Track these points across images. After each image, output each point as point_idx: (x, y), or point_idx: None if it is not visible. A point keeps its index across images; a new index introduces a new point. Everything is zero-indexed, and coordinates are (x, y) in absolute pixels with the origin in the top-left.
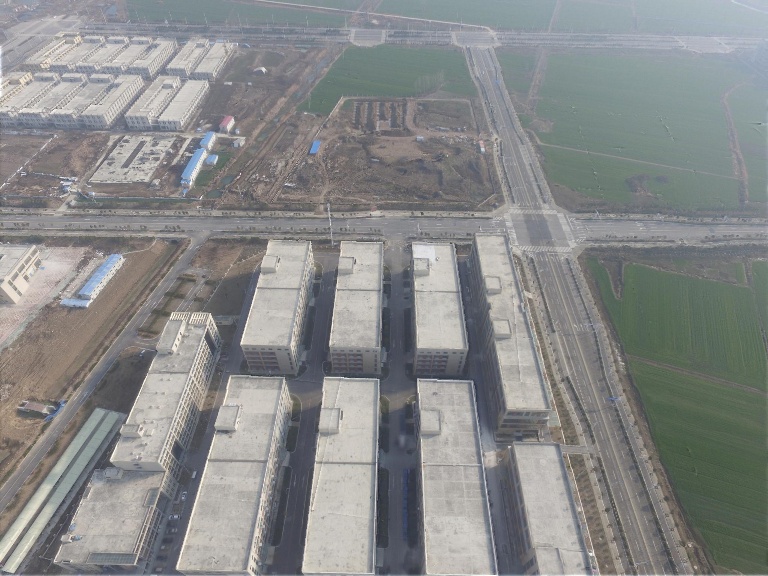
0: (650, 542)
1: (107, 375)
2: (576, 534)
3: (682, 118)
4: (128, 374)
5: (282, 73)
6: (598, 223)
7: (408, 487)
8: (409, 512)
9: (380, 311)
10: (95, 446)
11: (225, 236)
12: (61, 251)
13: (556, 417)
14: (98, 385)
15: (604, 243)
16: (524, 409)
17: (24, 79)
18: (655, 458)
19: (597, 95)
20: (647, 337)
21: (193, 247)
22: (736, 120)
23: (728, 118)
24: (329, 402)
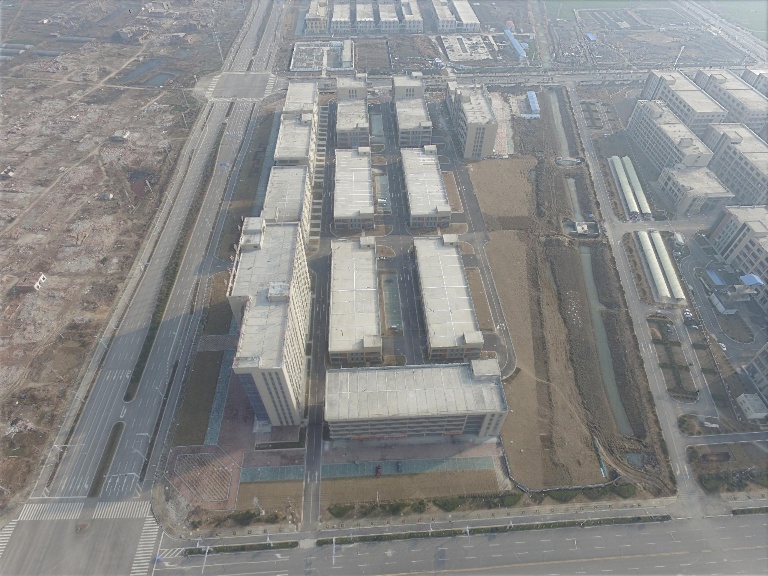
0: None
1: (596, 145)
2: None
3: None
4: (608, 144)
5: None
6: None
7: None
8: None
9: (764, 97)
10: (633, 169)
11: (586, 83)
12: None
13: None
14: (595, 149)
15: None
16: None
17: None
18: None
19: (764, 3)
20: None
21: (571, 89)
22: None
23: None
24: None
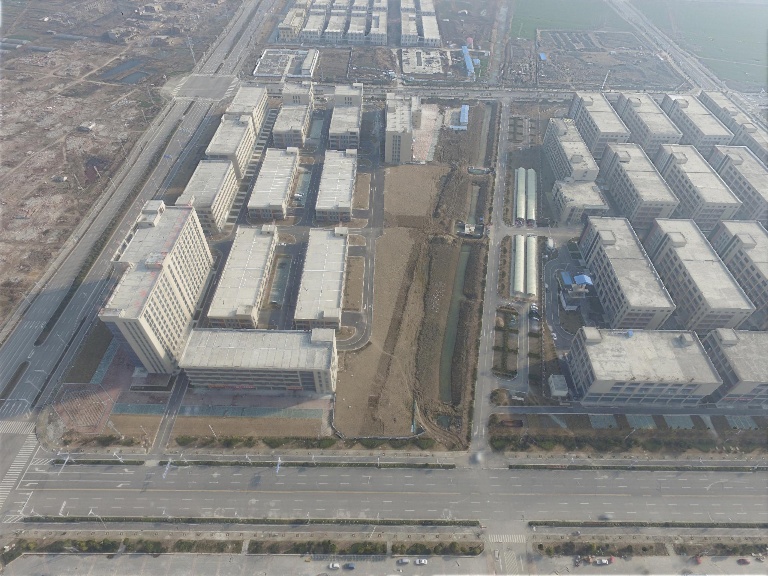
0: None
1: (509, 157)
2: None
3: None
4: (521, 157)
5: (479, 15)
6: (763, 98)
7: None
8: None
9: (670, 121)
10: None
11: (522, 100)
12: (422, 106)
13: None
14: (507, 161)
15: None
16: None
17: None
18: None
19: (724, 31)
20: None
21: (505, 105)
22: None
23: None
24: None
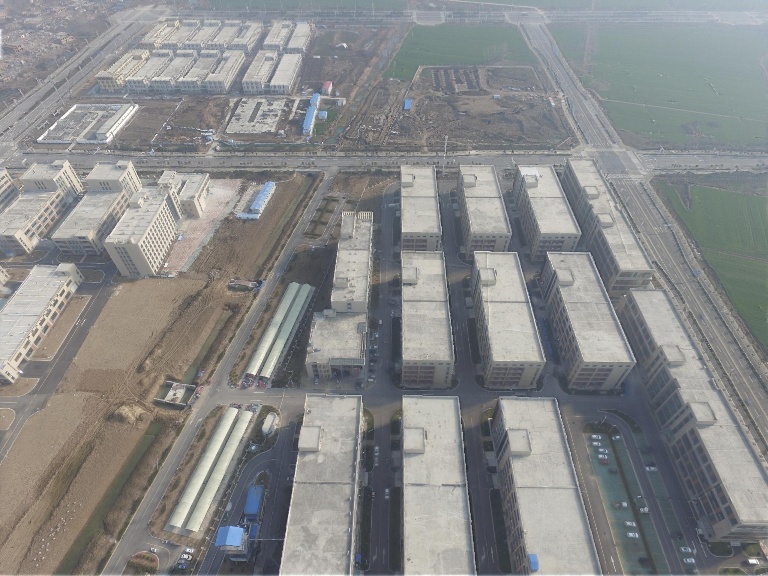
0: (737, 362)
1: (291, 262)
2: (688, 341)
3: (724, 78)
4: (307, 262)
5: (361, 48)
6: (663, 157)
7: (547, 328)
8: (551, 342)
9: (505, 210)
10: (300, 305)
11: (352, 170)
12: (222, 182)
13: (652, 287)
14: (286, 269)
15: (670, 171)
16: (634, 269)
17: (144, 55)
18: (734, 312)
19: (645, 61)
20: (716, 235)
21: (328, 178)
22: None
23: (766, 77)
24: (482, 267)
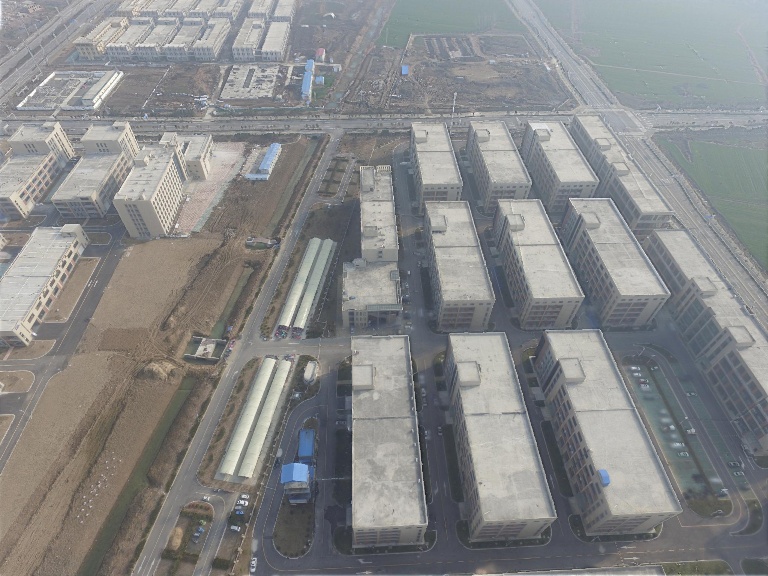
0: (756, 296)
1: (308, 219)
2: (716, 274)
3: (706, 45)
4: (324, 219)
5: (349, 18)
6: (660, 116)
7: (574, 271)
8: (580, 285)
9: (522, 162)
10: (325, 259)
11: (358, 131)
12: (224, 145)
13: None
14: (304, 226)
15: (669, 128)
16: (655, 212)
17: (123, 23)
18: (746, 253)
19: (630, 30)
20: (720, 185)
21: (334, 139)
22: (751, 45)
23: (744, 44)
24: None
